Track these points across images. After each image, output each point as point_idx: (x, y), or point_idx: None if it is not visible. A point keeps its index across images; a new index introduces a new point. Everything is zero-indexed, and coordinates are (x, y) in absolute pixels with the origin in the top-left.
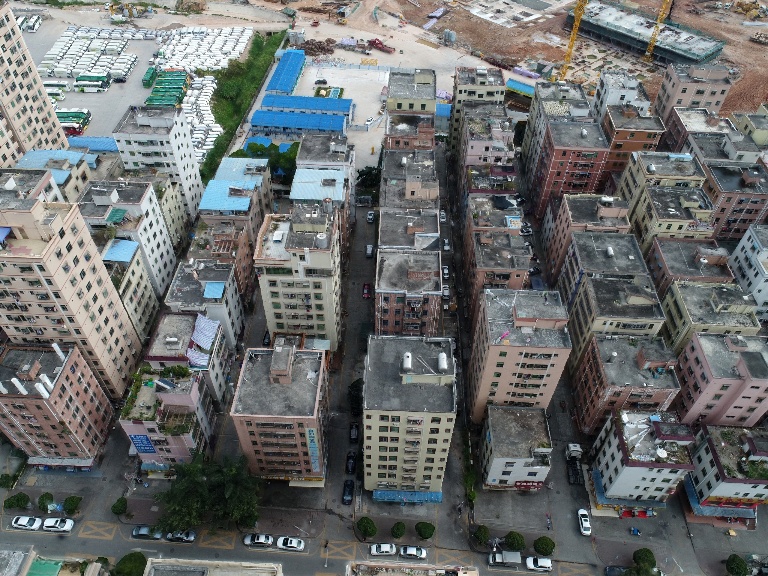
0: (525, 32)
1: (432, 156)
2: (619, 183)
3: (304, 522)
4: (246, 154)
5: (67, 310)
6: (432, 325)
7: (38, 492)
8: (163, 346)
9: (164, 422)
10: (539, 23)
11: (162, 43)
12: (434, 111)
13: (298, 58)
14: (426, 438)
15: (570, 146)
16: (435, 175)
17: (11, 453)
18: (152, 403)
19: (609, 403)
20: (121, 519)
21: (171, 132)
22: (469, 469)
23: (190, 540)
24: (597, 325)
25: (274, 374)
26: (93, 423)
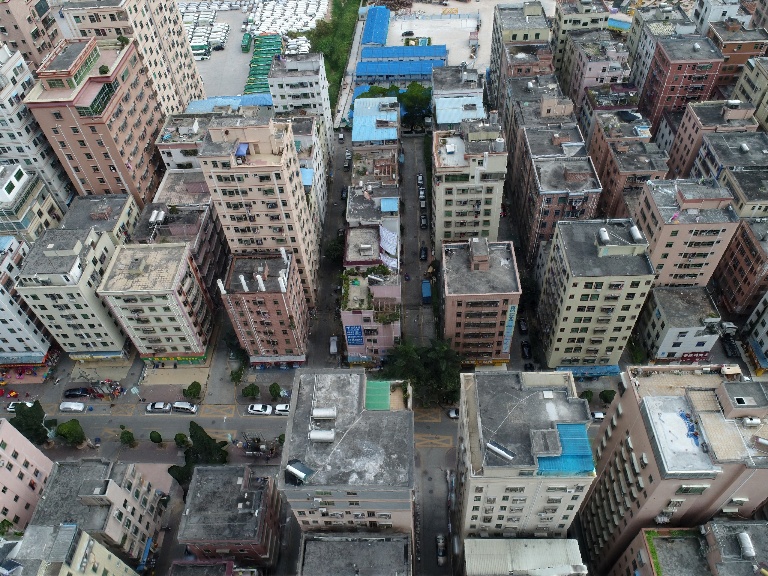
0: None
1: (554, 80)
2: (732, 93)
3: None
4: (370, 96)
5: (289, 218)
6: None
7: (261, 386)
8: (356, 254)
9: (379, 311)
10: None
11: (248, 11)
12: (547, 40)
13: (384, 12)
14: (620, 305)
15: (685, 60)
16: (562, 95)
17: (232, 355)
18: (363, 297)
19: (765, 278)
20: None
21: (319, 73)
22: (634, 349)
23: None
24: (746, 211)
25: (476, 260)
26: (303, 324)
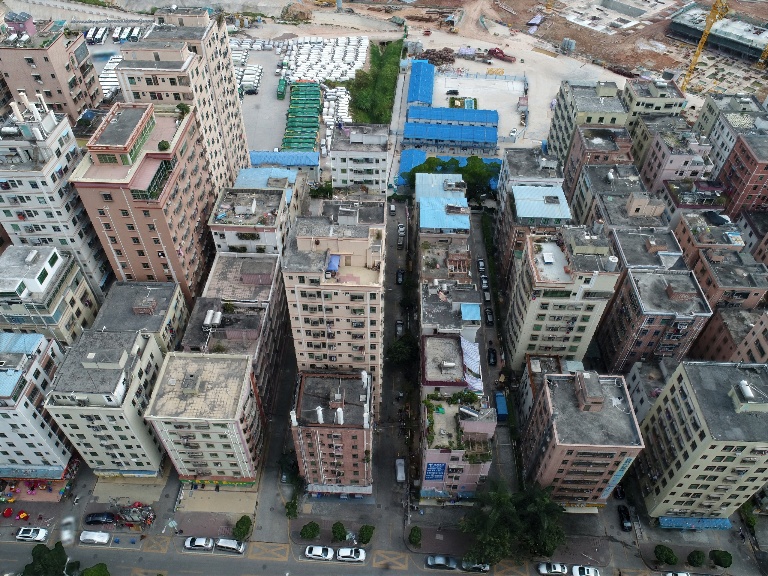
0: (629, 39)
1: (633, 171)
2: None
3: (590, 550)
4: (428, 169)
5: (374, 337)
6: (686, 346)
7: (319, 520)
8: (436, 370)
9: (470, 450)
10: (640, 30)
11: (283, 54)
12: (623, 125)
13: (429, 68)
14: (756, 467)
15: None
16: None
17: (286, 480)
18: (450, 431)
19: None
20: (410, 548)
21: None
22: None
23: (487, 570)
24: None
25: (589, 402)
26: None
